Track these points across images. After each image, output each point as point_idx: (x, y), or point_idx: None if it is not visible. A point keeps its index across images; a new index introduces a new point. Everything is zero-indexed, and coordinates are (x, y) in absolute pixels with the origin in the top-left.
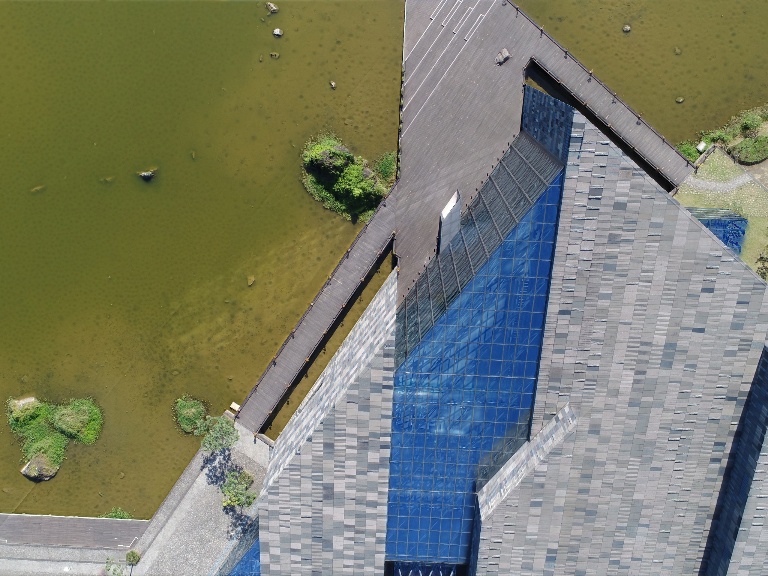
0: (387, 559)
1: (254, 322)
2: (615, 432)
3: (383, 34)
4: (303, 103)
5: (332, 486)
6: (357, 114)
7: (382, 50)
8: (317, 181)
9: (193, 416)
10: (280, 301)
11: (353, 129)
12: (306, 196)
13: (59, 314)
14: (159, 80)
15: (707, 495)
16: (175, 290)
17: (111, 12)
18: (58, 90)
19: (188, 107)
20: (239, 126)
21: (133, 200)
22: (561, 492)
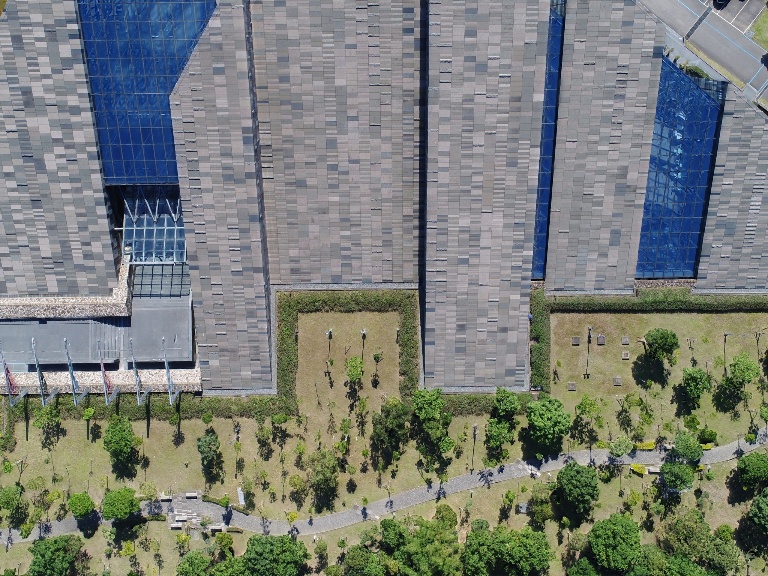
0: (107, 183)
1: None
2: (301, 2)
3: None
4: None
5: (30, 90)
6: None
7: None
8: None
9: None
10: None
11: None
12: None
13: None
14: None
15: (408, 76)
16: None
17: None
18: None
19: None
20: None
21: None
22: (241, 54)
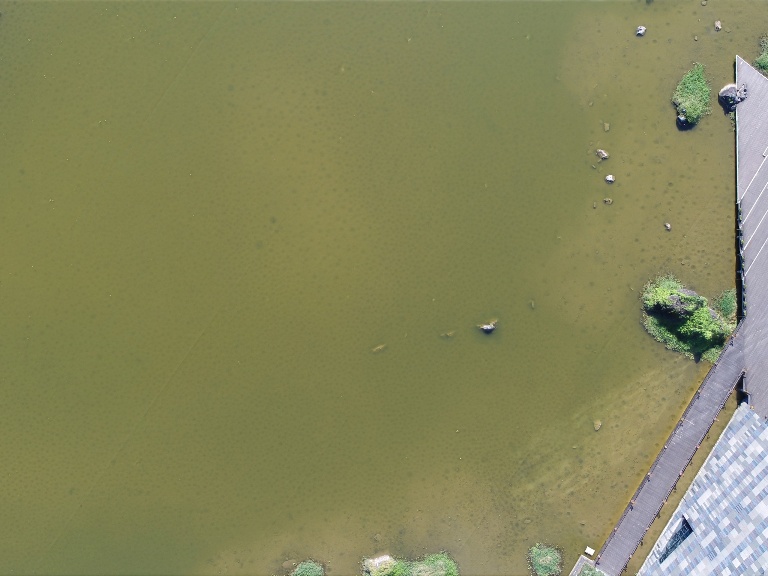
0: None
1: (603, 466)
2: None
3: (714, 173)
4: (639, 246)
5: None
6: (693, 254)
7: (714, 189)
8: (659, 323)
9: (550, 564)
10: (628, 443)
11: (690, 269)
12: (647, 338)
13: (408, 471)
14: (494, 233)
15: None
16: (522, 439)
17: (442, 169)
18: (394, 249)
19: (524, 257)
20: (576, 273)
21: (475, 353)
22: None
